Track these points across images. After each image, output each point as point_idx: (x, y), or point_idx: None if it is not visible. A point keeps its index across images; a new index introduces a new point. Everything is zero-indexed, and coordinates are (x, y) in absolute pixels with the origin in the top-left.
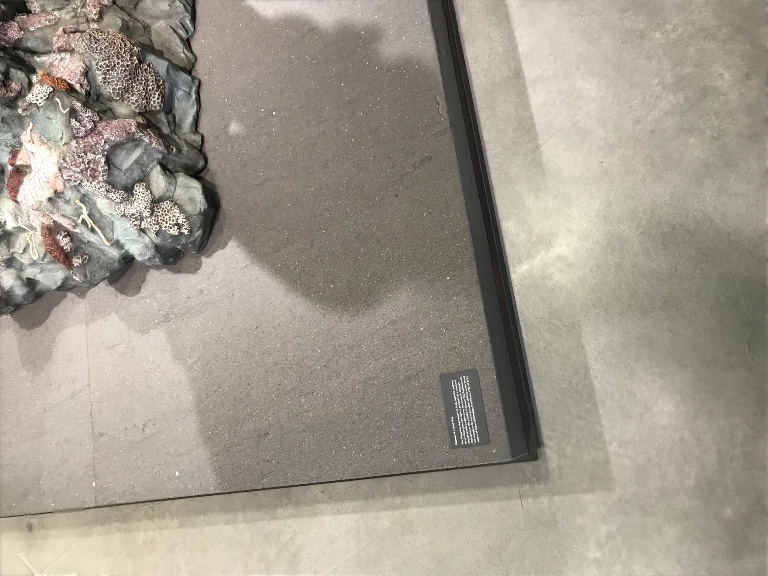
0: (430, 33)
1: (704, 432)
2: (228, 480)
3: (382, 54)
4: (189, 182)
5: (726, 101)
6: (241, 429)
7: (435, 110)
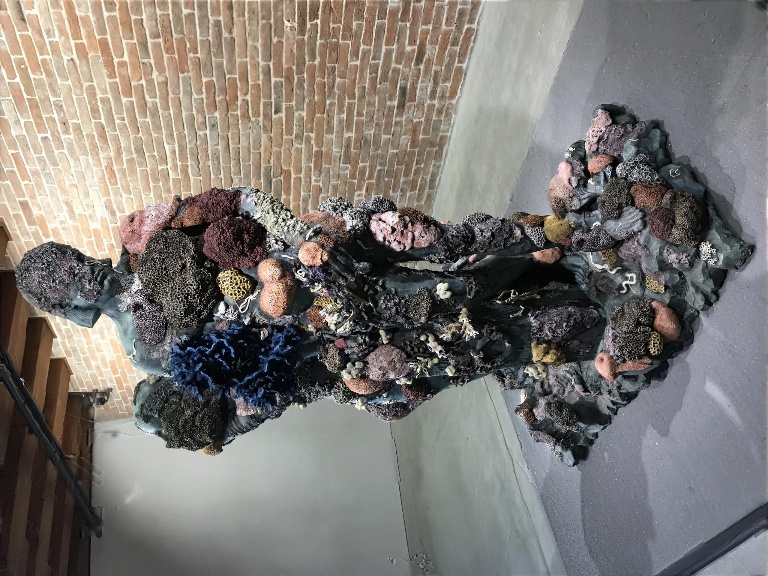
0: (660, 569)
1: None
2: (542, 499)
3: (647, 542)
4: (571, 456)
5: None
6: None
7: (642, 575)
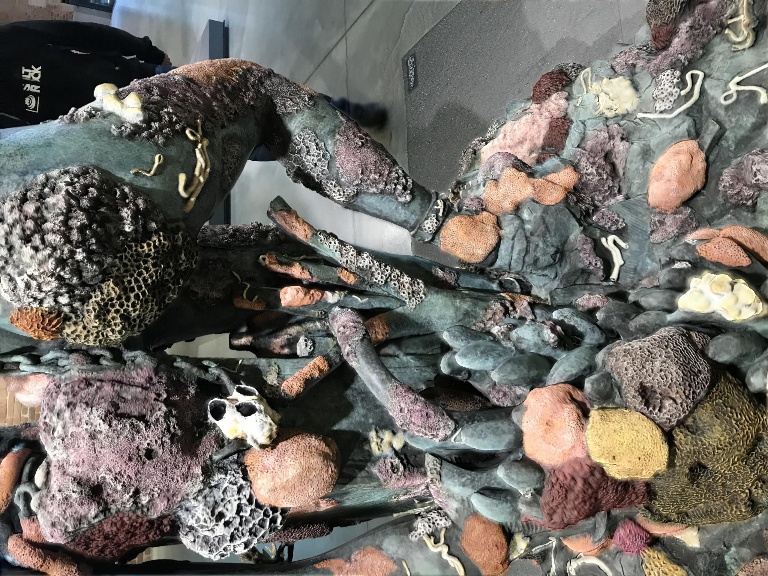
0: None
1: (400, 99)
2: None
3: None
4: None
5: (387, 237)
6: (495, 5)
7: None
